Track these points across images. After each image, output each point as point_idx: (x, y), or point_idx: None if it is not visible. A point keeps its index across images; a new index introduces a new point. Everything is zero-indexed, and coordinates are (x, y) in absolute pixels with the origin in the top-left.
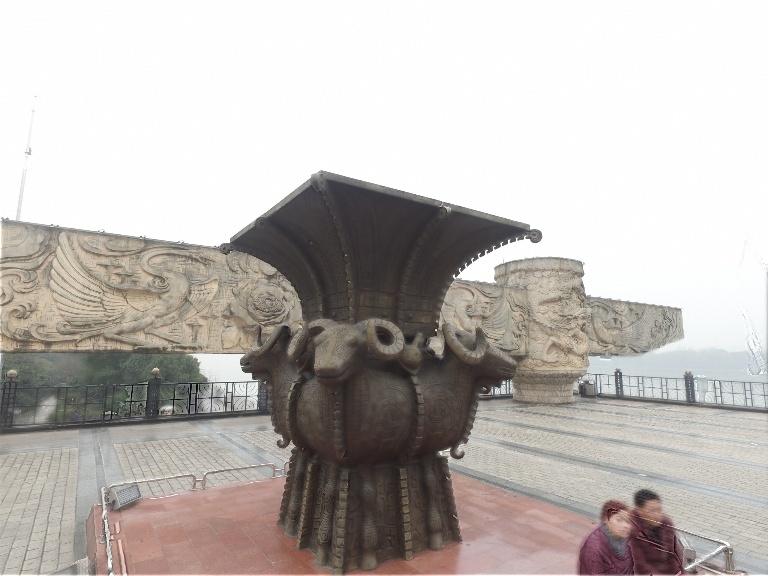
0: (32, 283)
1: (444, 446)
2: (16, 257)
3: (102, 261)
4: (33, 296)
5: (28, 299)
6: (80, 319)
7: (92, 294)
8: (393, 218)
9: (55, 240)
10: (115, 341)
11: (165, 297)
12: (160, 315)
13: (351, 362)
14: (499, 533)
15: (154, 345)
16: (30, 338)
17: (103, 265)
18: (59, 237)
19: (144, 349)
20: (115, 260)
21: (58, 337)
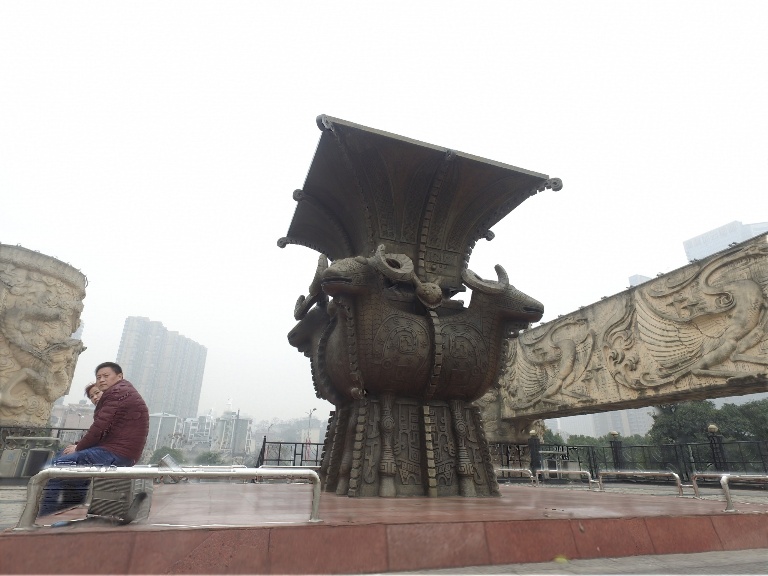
0: (629, 340)
1: (350, 385)
2: (616, 323)
3: (669, 301)
4: (635, 350)
5: (632, 353)
6: (669, 361)
7: (670, 335)
8: (315, 219)
9: (634, 299)
10: (706, 376)
11: (735, 314)
12: (739, 336)
13: (300, 328)
14: (358, 502)
15: (746, 373)
16: (642, 386)
17: (670, 304)
18: (635, 295)
19: (738, 380)
20: (679, 295)
21: (659, 381)
